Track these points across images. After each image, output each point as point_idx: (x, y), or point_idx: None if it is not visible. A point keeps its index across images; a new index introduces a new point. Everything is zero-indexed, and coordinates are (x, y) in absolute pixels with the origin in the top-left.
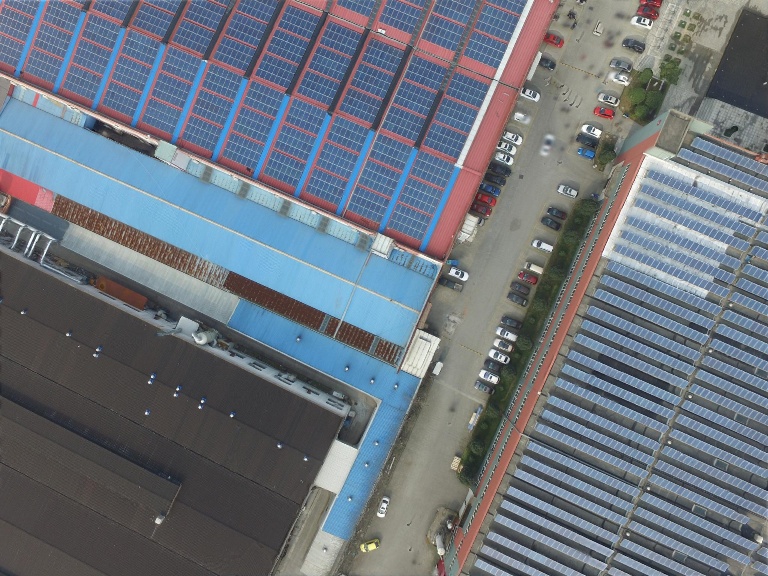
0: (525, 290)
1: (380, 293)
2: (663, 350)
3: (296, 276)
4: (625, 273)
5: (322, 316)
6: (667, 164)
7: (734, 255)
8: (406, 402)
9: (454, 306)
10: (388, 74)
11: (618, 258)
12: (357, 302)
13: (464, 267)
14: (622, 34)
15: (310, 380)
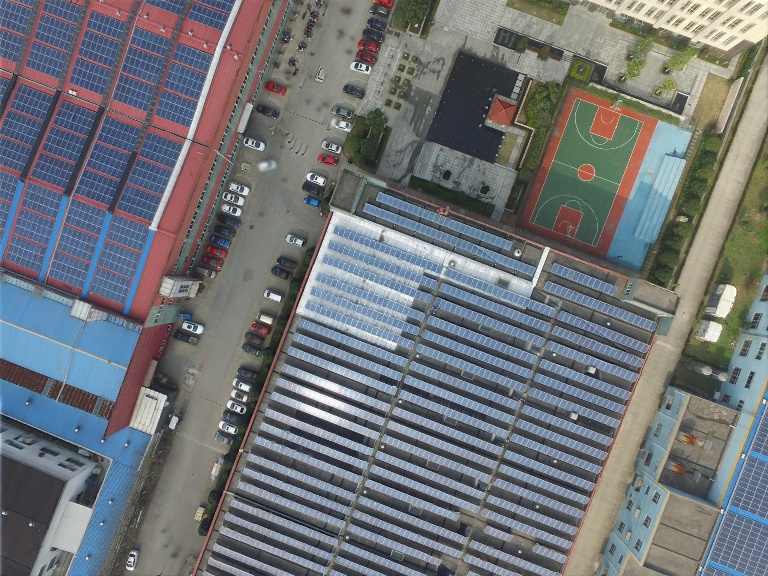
0: (257, 340)
1: (98, 355)
2: (356, 403)
3: (15, 342)
4: (315, 330)
5: (45, 380)
6: (354, 219)
7: (420, 307)
8: (137, 460)
9: (192, 359)
10: (81, 137)
11: (311, 314)
12: (78, 365)
13: (200, 320)
14: (343, 80)
15: (55, 439)
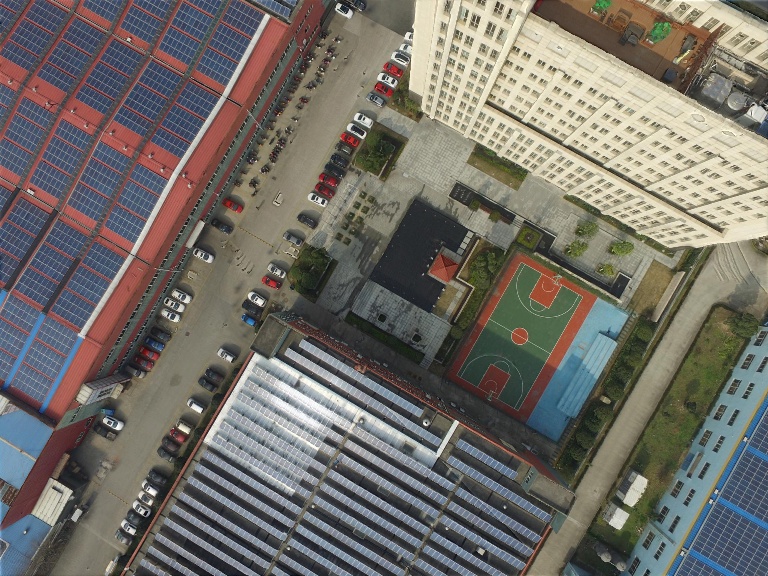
0: (173, 447)
1: (12, 443)
2: (246, 542)
3: None
4: (218, 463)
5: None
6: (274, 361)
7: (324, 457)
8: (33, 549)
9: (108, 453)
10: (30, 235)
11: (217, 446)
12: None
13: (122, 416)
14: (299, 207)
15: None
